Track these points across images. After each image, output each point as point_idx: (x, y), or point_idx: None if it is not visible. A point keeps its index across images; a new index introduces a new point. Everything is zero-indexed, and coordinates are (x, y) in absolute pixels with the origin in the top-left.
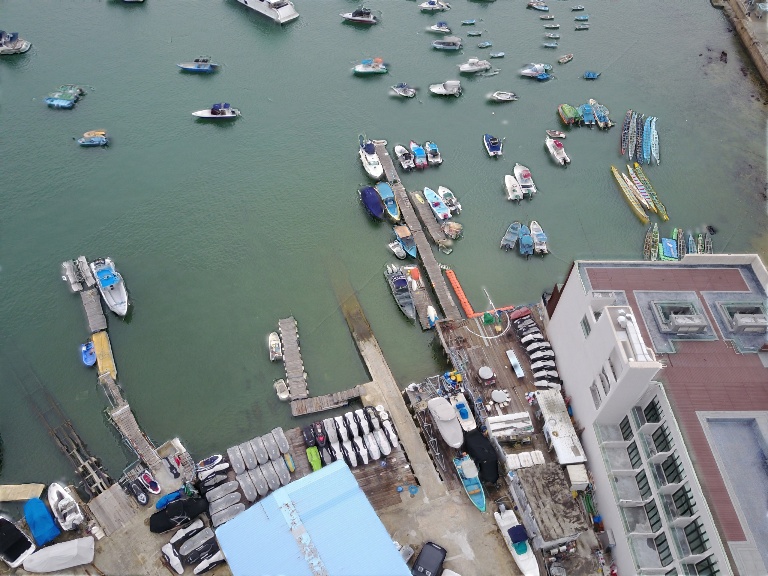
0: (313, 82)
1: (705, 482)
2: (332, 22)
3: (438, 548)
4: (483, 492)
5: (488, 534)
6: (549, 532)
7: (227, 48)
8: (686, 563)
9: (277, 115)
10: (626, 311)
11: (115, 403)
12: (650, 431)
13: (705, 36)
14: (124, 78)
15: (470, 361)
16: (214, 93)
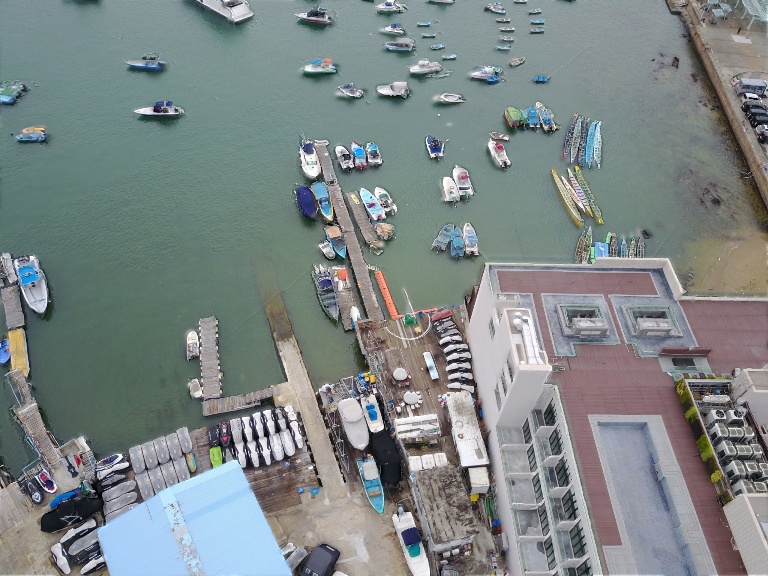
0: (261, 81)
1: (588, 486)
2: (287, 22)
3: (331, 550)
4: (383, 494)
5: (385, 536)
6: (440, 535)
7: (179, 46)
8: (567, 567)
9: (222, 114)
10: (525, 314)
11: (22, 401)
12: (546, 434)
13: (659, 41)
14: (71, 74)
15: (386, 362)
16: (161, 91)
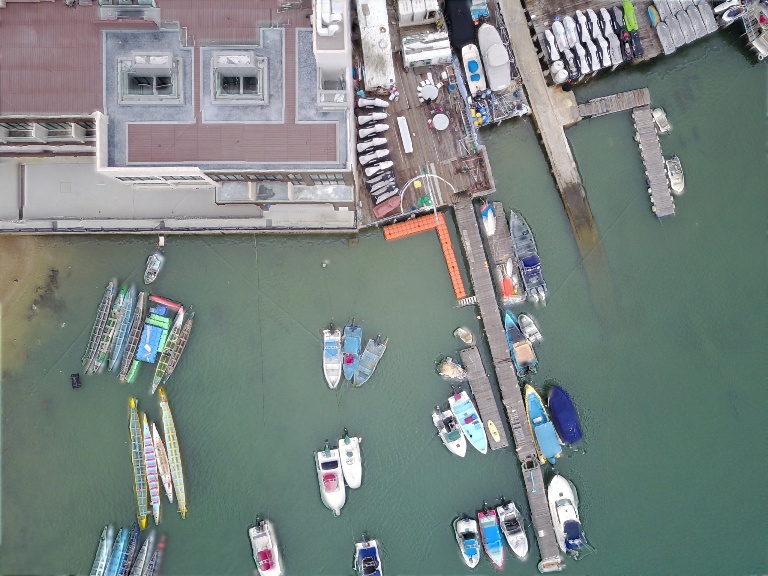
0: None
1: None
2: None
3: None
4: None
5: None
6: None
7: None
8: None
9: None
10: (322, 45)
11: None
12: None
13: None
14: None
15: (455, 142)
16: None
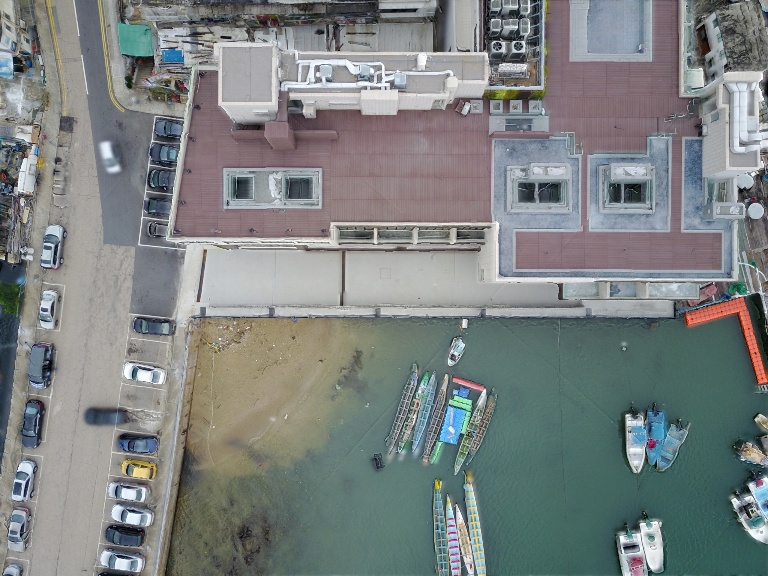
0: None
1: None
2: None
3: None
4: None
5: None
6: (755, 7)
7: None
8: None
9: None
10: (734, 162)
11: None
12: None
13: None
14: None
15: (767, 231)
16: None
